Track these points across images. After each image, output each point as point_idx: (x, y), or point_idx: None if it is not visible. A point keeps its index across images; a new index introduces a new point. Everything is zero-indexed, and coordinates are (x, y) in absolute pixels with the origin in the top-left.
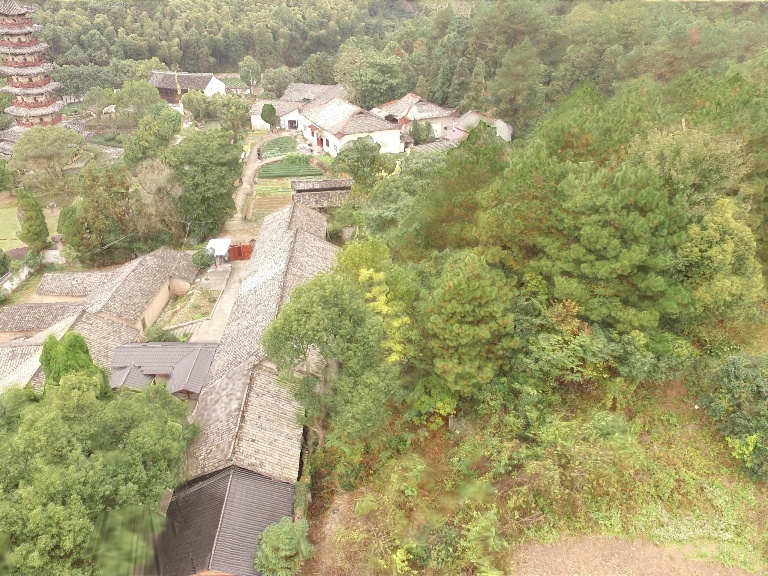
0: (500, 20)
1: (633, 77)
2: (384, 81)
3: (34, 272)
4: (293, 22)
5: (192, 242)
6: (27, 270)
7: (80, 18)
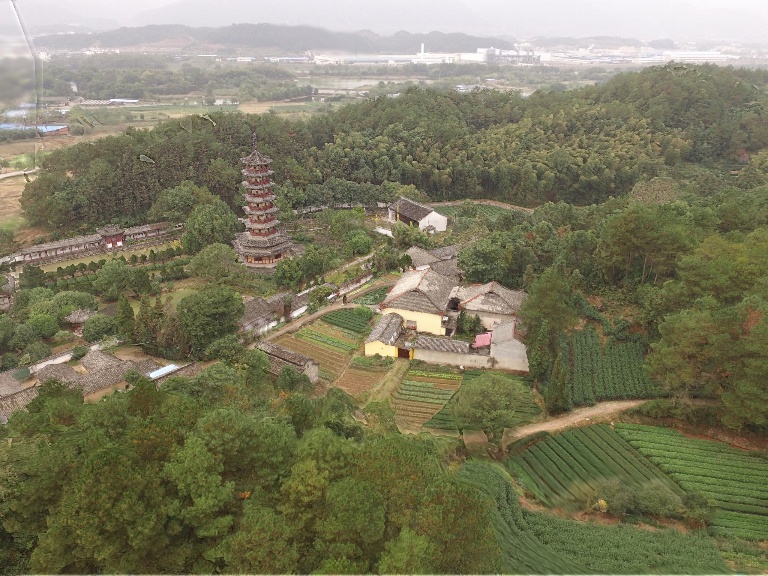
0: (619, 231)
1: (667, 344)
2: (473, 265)
3: (122, 343)
4: (565, 165)
5: (193, 358)
6: (117, 341)
7: (381, 146)
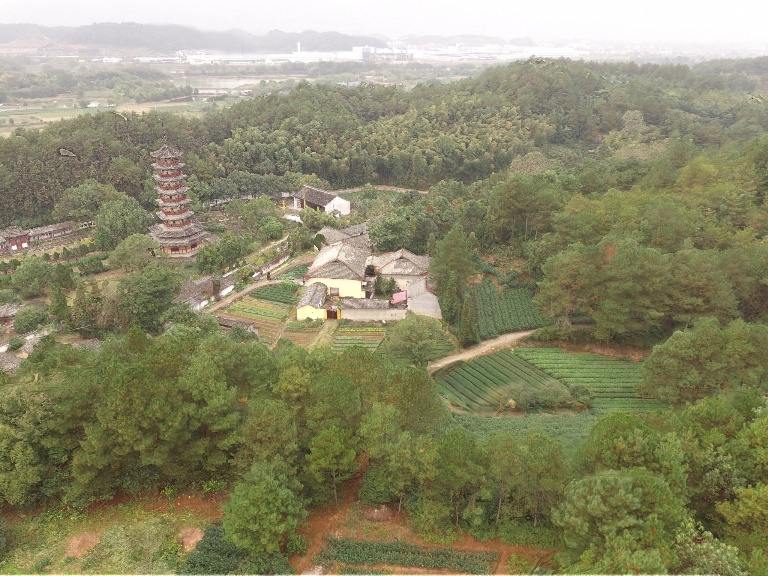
0: (504, 197)
1: (550, 280)
2: (384, 235)
3: None
4: (450, 150)
5: None
6: None
7: (280, 139)
